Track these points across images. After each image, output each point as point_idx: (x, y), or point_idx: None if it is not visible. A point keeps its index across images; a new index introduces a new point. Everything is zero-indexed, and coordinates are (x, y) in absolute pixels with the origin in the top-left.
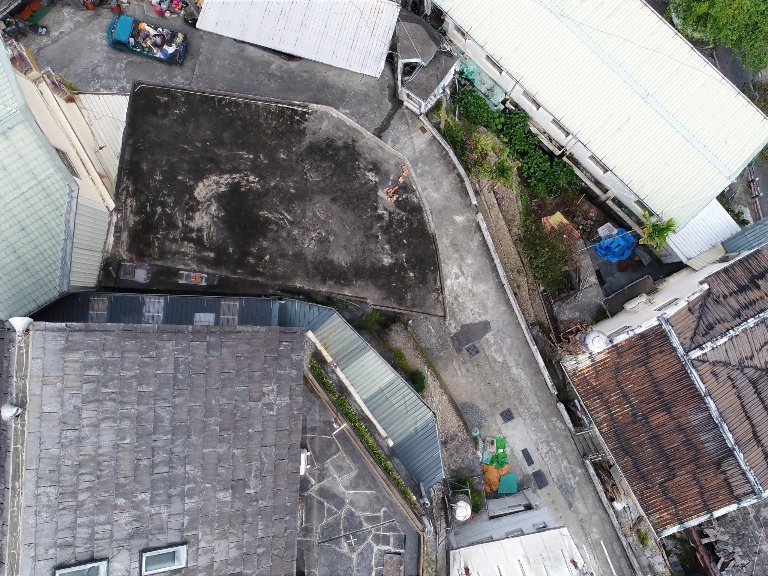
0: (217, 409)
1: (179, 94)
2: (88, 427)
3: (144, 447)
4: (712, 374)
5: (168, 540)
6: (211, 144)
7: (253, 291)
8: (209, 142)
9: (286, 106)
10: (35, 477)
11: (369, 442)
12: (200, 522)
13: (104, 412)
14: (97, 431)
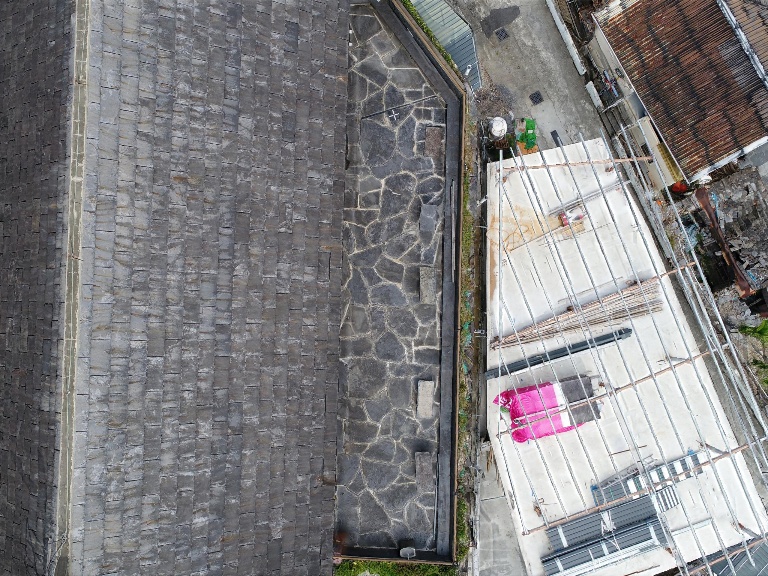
0: None
1: None
2: None
3: None
4: (743, 10)
5: None
6: None
7: None
8: None
9: None
10: None
11: (411, 9)
12: None
13: None
14: None
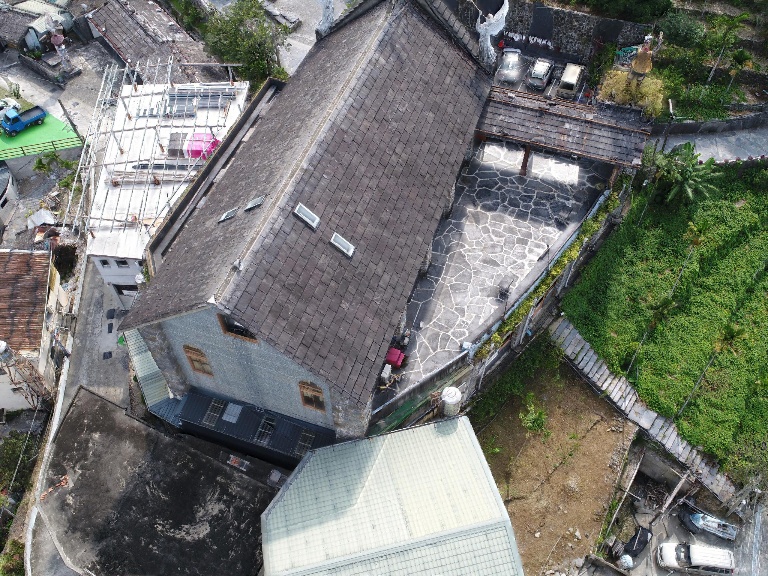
0: None
1: None
2: None
3: None
4: None
5: None
6: (177, 568)
7: (200, 441)
8: (178, 570)
9: None
10: None
11: None
12: None
13: None
14: None
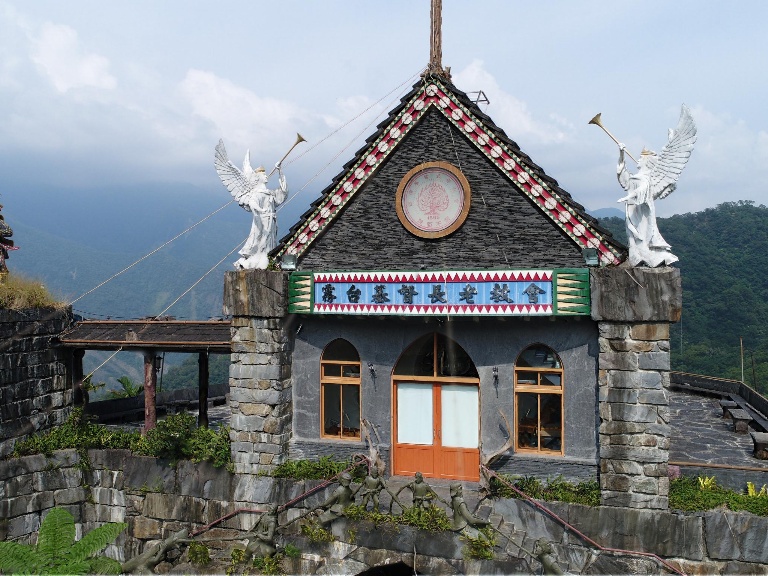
0: None
1: None
2: None
3: None
4: None
5: None
6: None
7: None
8: None
9: None
10: None
11: None
12: None
13: None
14: None
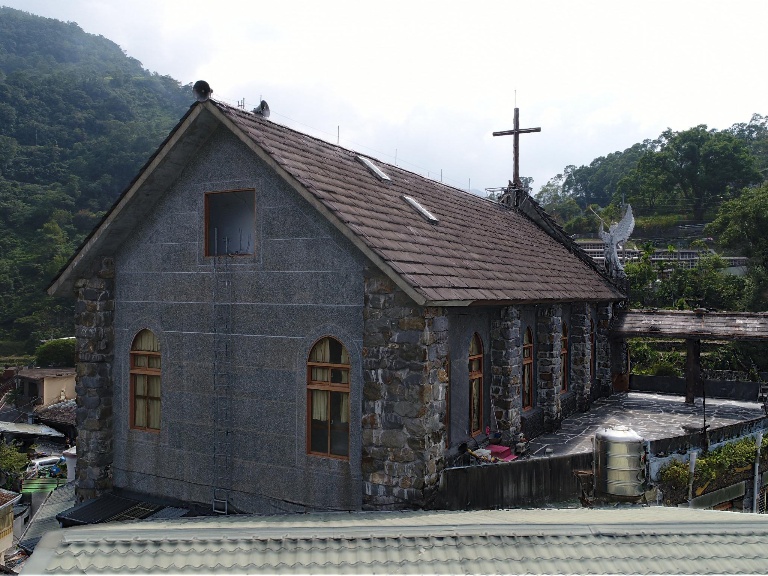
0: None
1: None
2: None
3: None
4: None
5: None
6: None
7: None
8: None
9: None
10: None
11: None
12: None
13: None
14: None
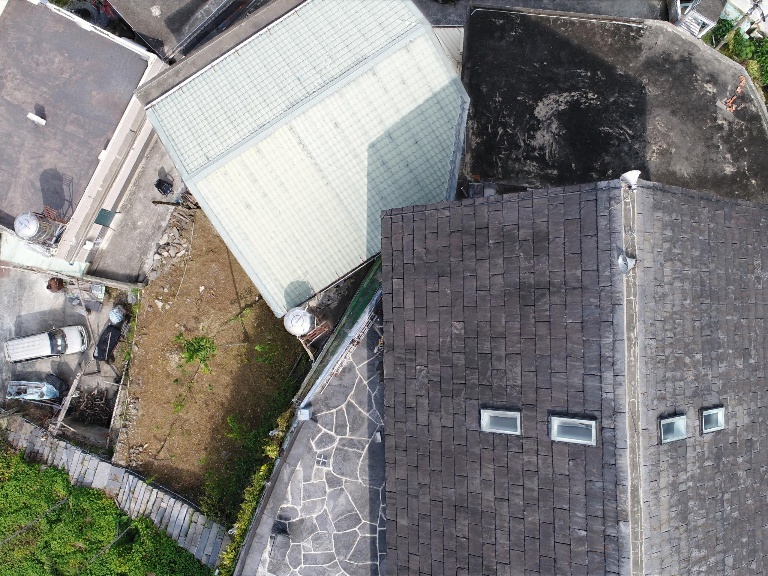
0: (732, 278)
1: (514, 16)
2: (667, 285)
3: (696, 309)
4: None
5: (712, 402)
6: (549, 64)
7: None
8: (547, 62)
9: (621, 23)
10: (644, 329)
11: None
12: (728, 387)
13: (675, 272)
14: (673, 289)
